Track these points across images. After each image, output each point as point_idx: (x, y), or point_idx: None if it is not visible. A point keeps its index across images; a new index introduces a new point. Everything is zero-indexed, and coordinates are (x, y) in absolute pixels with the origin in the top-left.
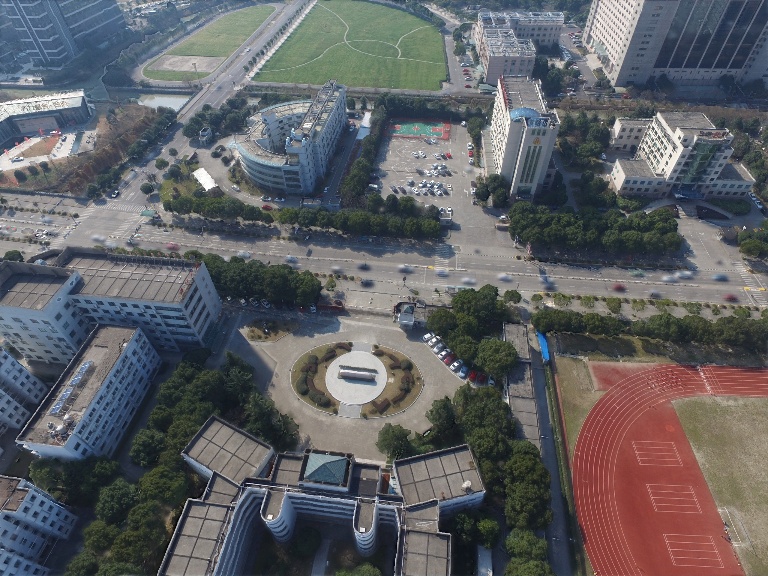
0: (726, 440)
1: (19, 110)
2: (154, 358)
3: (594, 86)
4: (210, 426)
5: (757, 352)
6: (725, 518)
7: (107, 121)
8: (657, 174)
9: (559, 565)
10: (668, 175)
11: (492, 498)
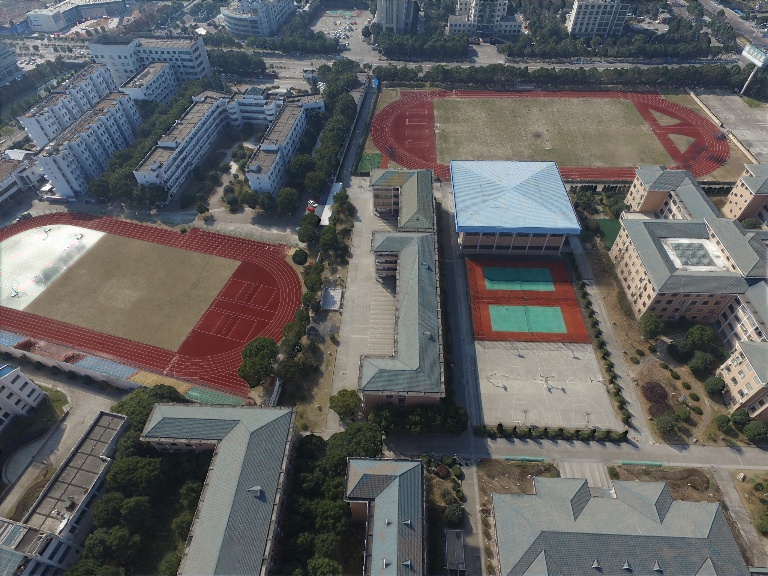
0: (452, 108)
1: (82, 2)
2: (177, 86)
3: None
4: (205, 91)
5: (487, 86)
6: None
7: (139, 12)
8: (468, 20)
9: (357, 136)
10: (472, 19)
11: (329, 110)
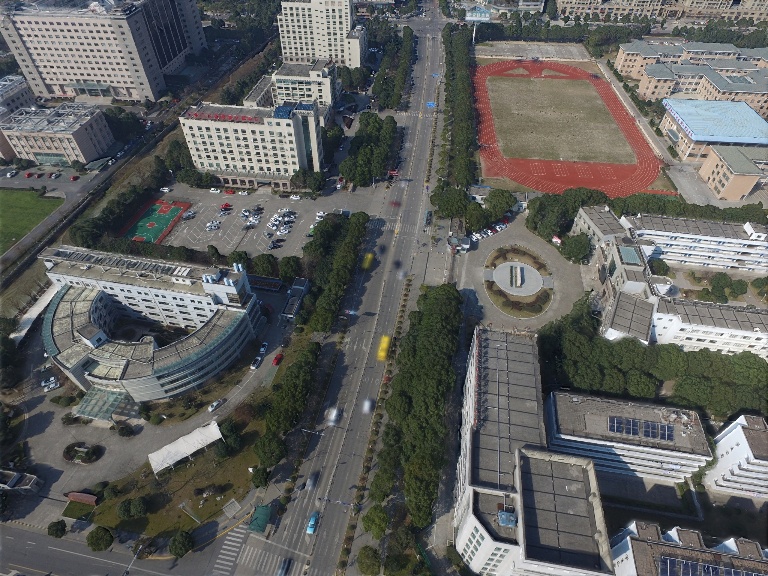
0: (524, 149)
1: None
2: None
3: (146, 109)
4: (618, 330)
5: None
6: (565, 160)
7: None
8: (323, 106)
9: None
10: (330, 101)
11: None
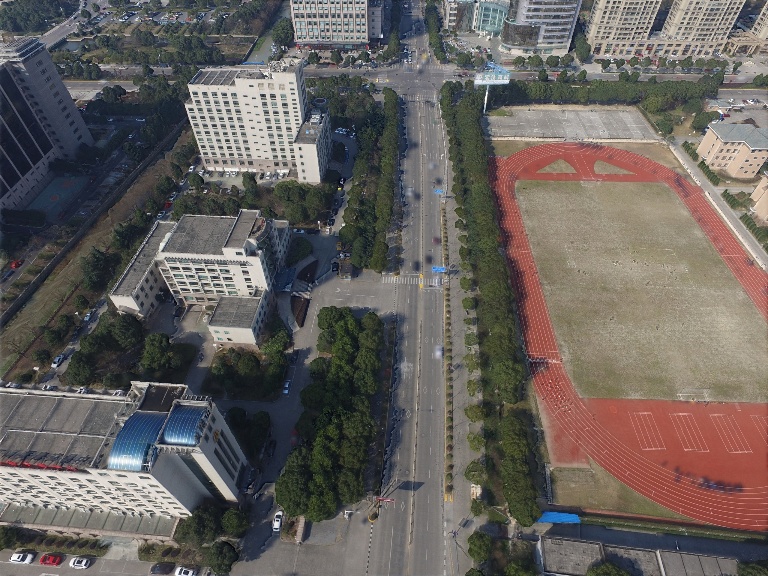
0: (609, 369)
1: None
2: None
3: None
4: None
5: None
6: (687, 398)
7: None
8: (254, 295)
9: None
10: (265, 286)
11: None
